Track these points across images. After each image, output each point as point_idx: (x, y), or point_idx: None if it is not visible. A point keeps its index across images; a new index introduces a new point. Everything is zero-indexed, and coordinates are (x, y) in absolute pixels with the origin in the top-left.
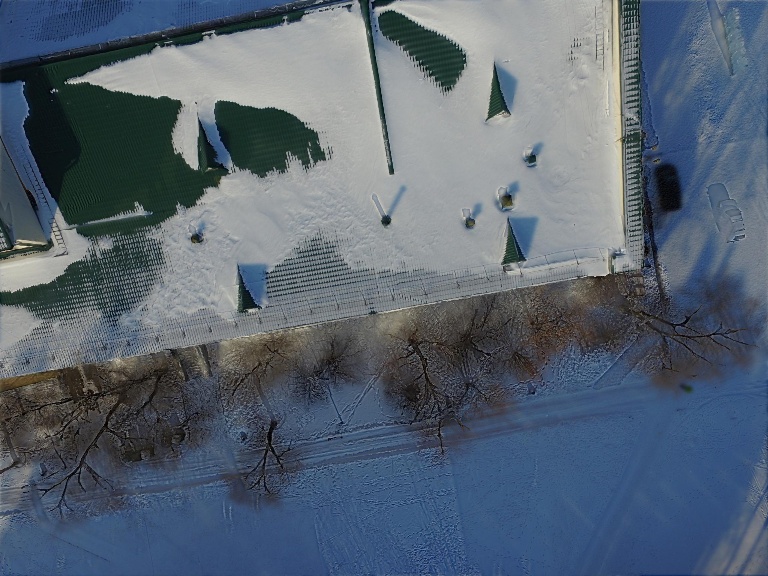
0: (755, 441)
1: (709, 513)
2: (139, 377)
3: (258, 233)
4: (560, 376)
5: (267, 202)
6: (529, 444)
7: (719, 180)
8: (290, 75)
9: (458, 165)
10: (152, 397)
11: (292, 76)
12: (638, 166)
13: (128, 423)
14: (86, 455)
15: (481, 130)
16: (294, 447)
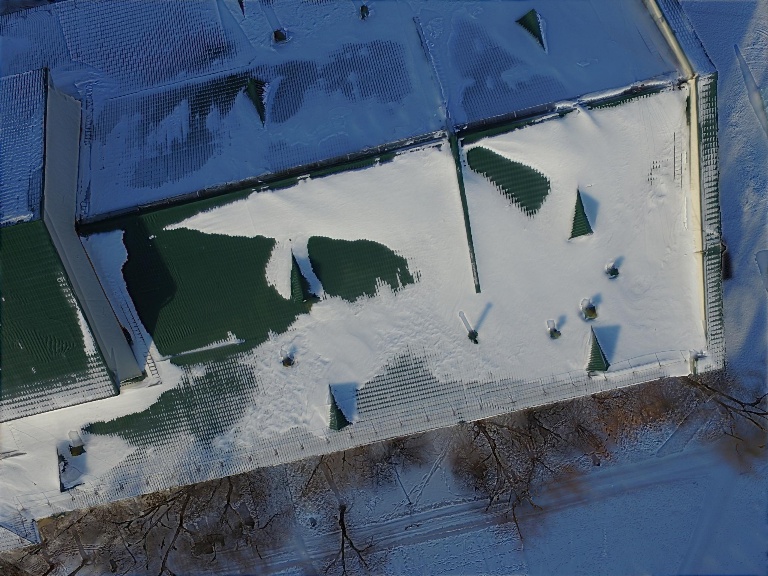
0: None
1: None
2: None
3: (348, 354)
4: (623, 446)
5: (357, 324)
6: (597, 515)
7: (766, 247)
8: (382, 210)
9: (542, 280)
10: (229, 497)
11: (384, 211)
12: (718, 275)
13: (197, 515)
14: (166, 559)
15: (564, 248)
16: (376, 543)
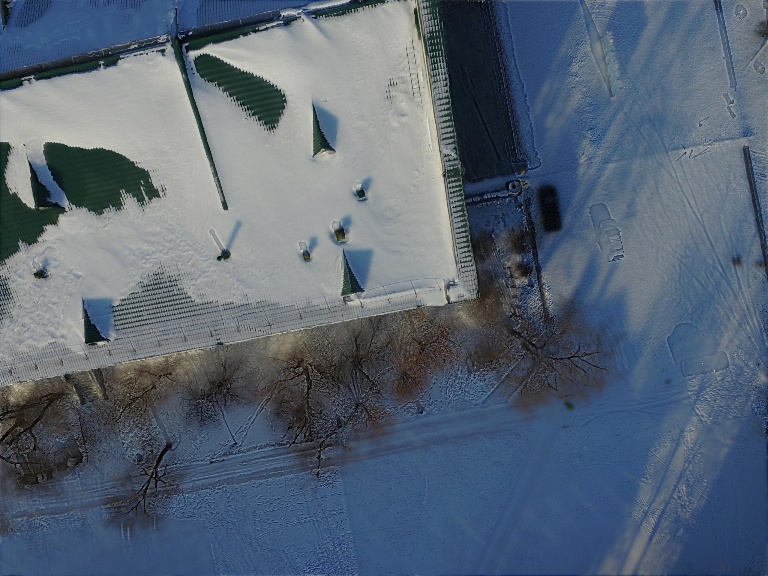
0: (639, 457)
1: (595, 529)
2: (36, 401)
3: (100, 268)
4: (448, 395)
5: (107, 238)
6: (419, 462)
7: (600, 200)
8: (113, 117)
9: (290, 200)
10: (35, 423)
11: (115, 118)
12: (462, 200)
13: (26, 446)
14: None
15: (309, 166)
16: (169, 472)
